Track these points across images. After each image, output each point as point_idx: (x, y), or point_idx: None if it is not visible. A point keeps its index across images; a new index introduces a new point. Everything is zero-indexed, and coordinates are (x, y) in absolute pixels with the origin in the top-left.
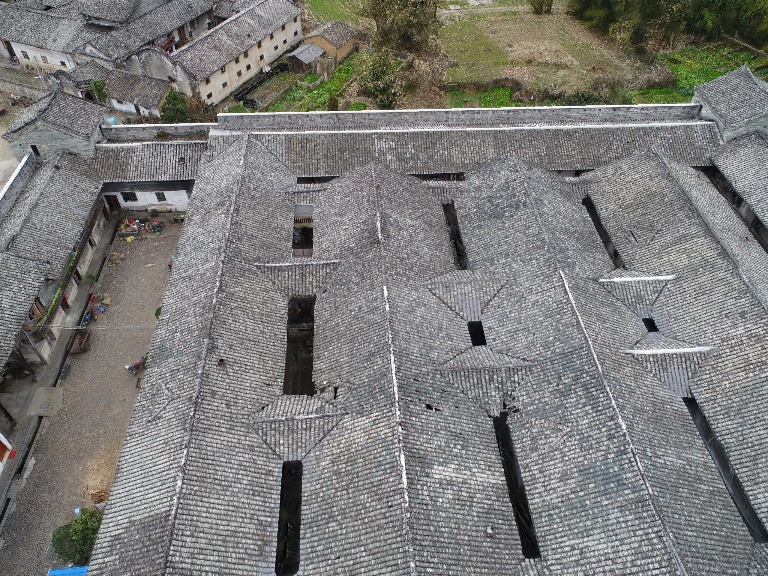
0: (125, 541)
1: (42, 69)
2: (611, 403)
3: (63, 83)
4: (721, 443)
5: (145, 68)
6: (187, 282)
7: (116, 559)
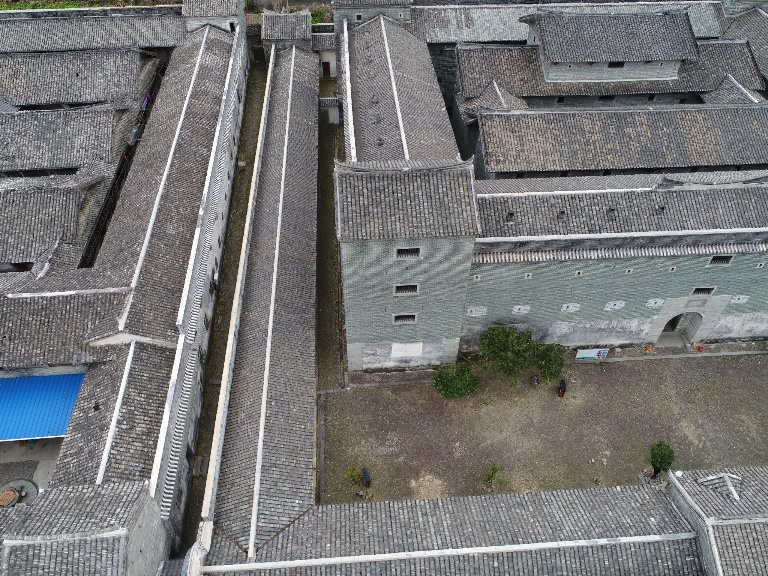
0: None
1: None
2: (3, 114)
3: None
4: (53, 103)
5: None
6: None
7: None
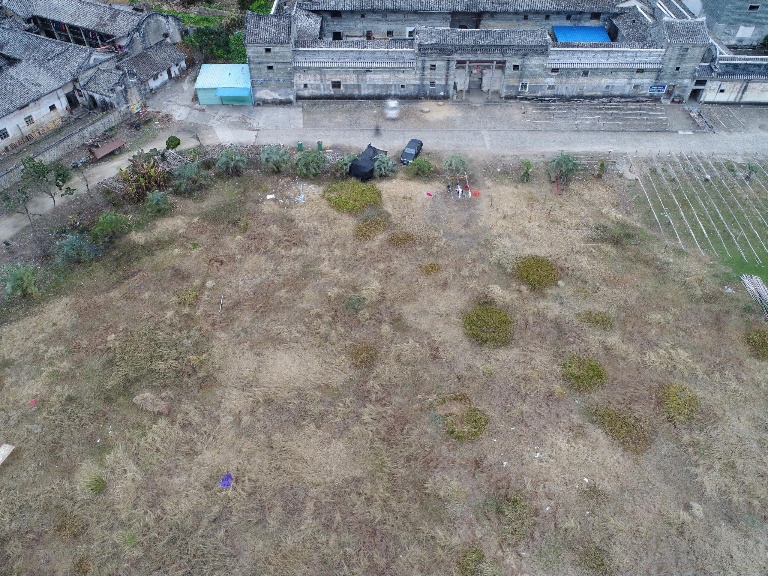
0: (558, 1)
1: (27, 136)
2: None
3: (127, 86)
4: None
5: (144, 40)
6: (431, 0)
7: (564, 2)
